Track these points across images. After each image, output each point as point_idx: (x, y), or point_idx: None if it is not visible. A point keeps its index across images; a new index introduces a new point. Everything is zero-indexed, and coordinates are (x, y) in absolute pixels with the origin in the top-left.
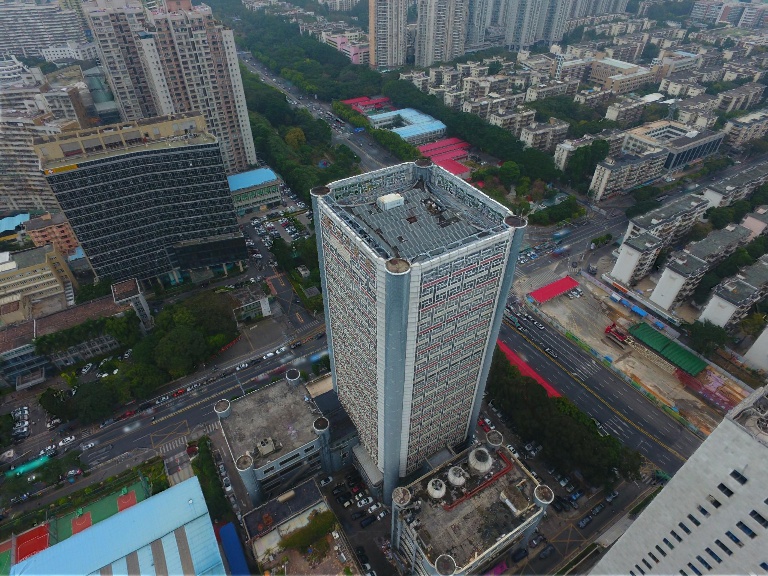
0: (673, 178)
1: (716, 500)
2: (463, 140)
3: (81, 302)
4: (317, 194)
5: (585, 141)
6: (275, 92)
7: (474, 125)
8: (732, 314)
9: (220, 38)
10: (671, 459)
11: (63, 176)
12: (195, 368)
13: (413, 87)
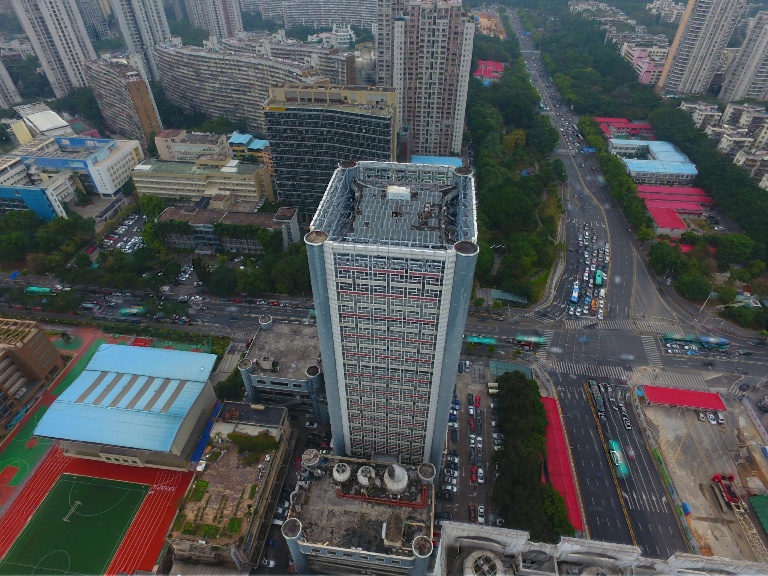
0: None
1: None
2: (709, 194)
3: (258, 211)
4: (342, 166)
5: None
6: (527, 93)
7: (730, 180)
8: None
9: (462, 29)
10: None
11: (275, 114)
12: (295, 292)
13: (686, 120)
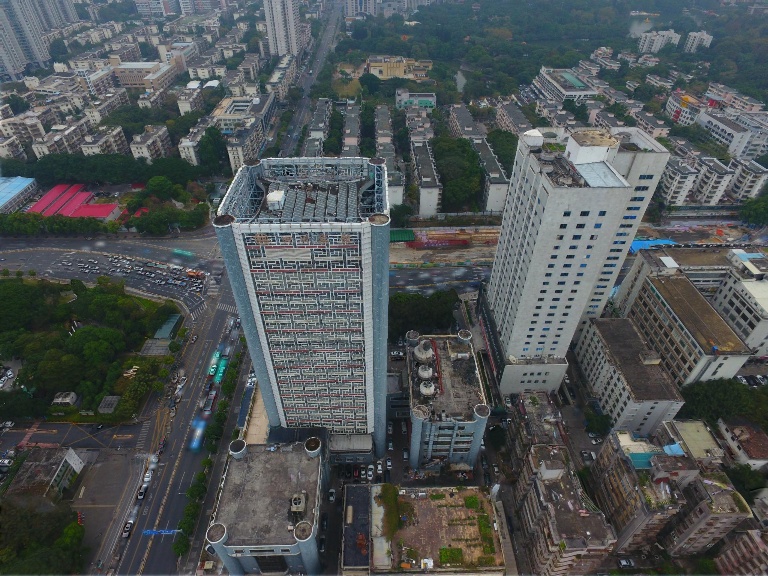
0: (271, 137)
1: (561, 236)
2: (70, 183)
3: None
4: (225, 224)
5: (196, 134)
6: None
7: (74, 163)
8: (402, 193)
9: None
10: (452, 287)
11: None
12: None
13: None
